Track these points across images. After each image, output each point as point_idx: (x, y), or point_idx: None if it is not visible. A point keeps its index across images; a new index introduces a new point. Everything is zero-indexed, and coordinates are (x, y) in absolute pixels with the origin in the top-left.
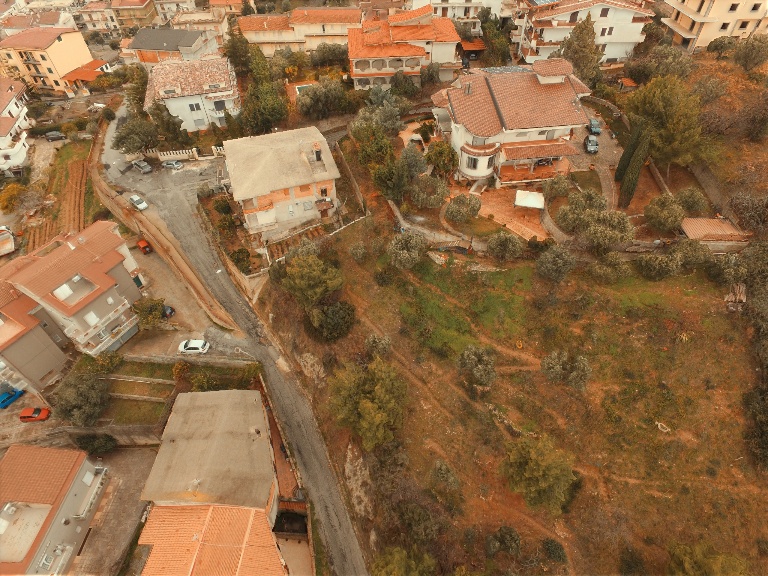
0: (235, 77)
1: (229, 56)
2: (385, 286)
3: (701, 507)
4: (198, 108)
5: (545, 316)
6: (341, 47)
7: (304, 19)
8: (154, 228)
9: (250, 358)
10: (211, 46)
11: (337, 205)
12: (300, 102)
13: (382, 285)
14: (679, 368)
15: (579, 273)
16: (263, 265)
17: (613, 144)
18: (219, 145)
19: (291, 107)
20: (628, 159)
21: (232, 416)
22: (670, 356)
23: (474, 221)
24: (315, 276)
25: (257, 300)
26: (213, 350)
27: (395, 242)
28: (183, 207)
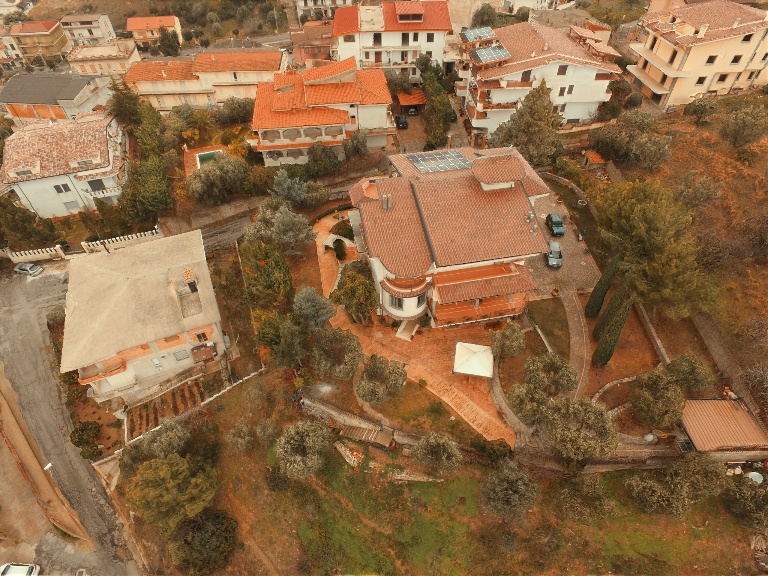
0: (125, 139)
1: (115, 115)
2: (278, 492)
3: None
4: (67, 189)
5: (498, 558)
6: (253, 102)
7: (210, 66)
8: None
9: None
10: (105, 94)
11: (225, 347)
12: (190, 187)
13: (274, 490)
14: None
15: (543, 490)
16: (120, 441)
17: (580, 250)
18: (93, 238)
19: (181, 191)
20: (602, 296)
21: None
22: None
23: None
24: (167, 500)
25: None
26: None
27: (285, 439)
28: (32, 336)
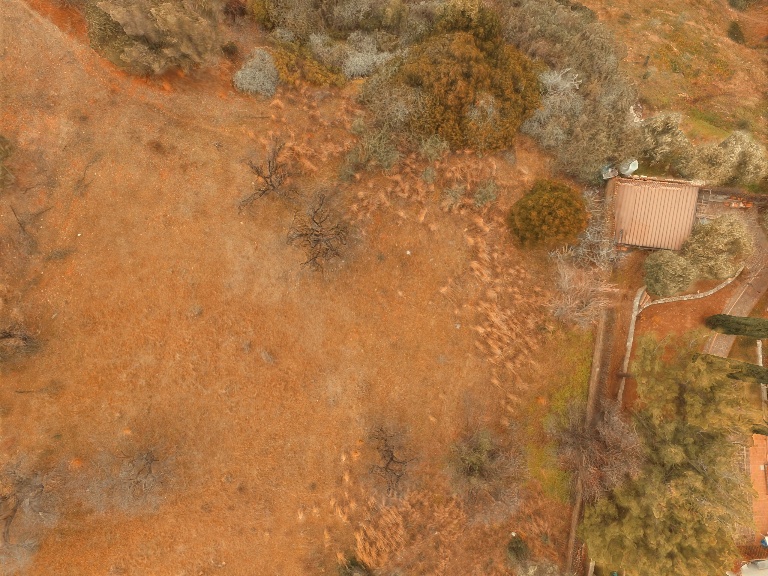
0: None
1: None
2: None
3: (631, 2)
4: None
5: None
6: None
7: None
8: None
9: None
10: None
11: None
12: None
13: None
14: None
15: None
16: None
17: None
18: None
19: None
20: None
21: None
22: None
23: None
24: None
25: None
26: None
27: None
28: None
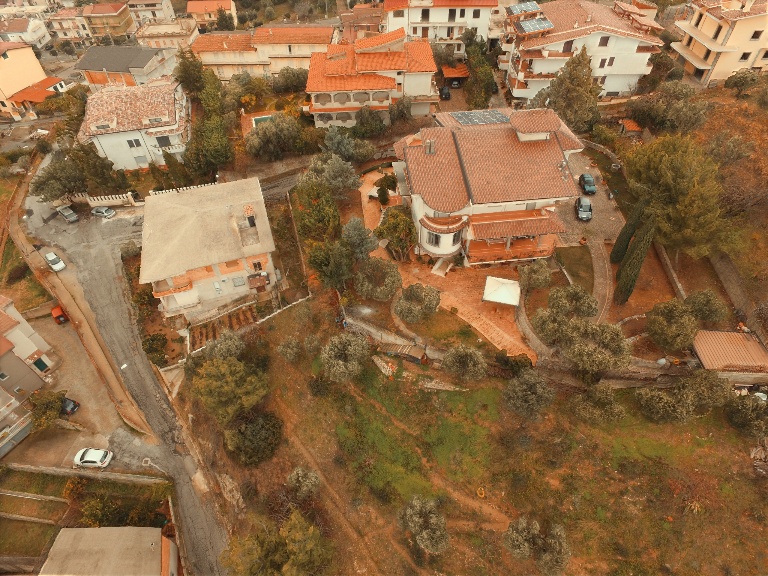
0: (189, 104)
1: (181, 81)
2: (320, 397)
3: None
4: (138, 144)
5: (514, 458)
6: (306, 72)
7: (268, 39)
8: (68, 296)
9: (160, 474)
10: (170, 65)
11: (276, 278)
12: (248, 143)
13: (317, 395)
14: (688, 548)
15: (559, 401)
16: (183, 353)
17: (610, 207)
18: (159, 188)
19: (239, 147)
20: (627, 240)
21: (119, 568)
22: (677, 530)
23: (433, 316)
24: (227, 391)
25: (177, 394)
26: (117, 461)
27: (330, 347)
28: (107, 267)
